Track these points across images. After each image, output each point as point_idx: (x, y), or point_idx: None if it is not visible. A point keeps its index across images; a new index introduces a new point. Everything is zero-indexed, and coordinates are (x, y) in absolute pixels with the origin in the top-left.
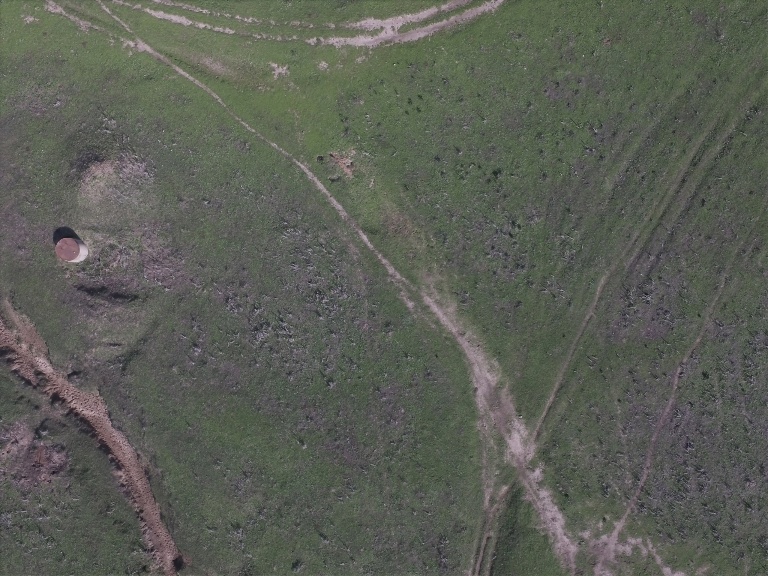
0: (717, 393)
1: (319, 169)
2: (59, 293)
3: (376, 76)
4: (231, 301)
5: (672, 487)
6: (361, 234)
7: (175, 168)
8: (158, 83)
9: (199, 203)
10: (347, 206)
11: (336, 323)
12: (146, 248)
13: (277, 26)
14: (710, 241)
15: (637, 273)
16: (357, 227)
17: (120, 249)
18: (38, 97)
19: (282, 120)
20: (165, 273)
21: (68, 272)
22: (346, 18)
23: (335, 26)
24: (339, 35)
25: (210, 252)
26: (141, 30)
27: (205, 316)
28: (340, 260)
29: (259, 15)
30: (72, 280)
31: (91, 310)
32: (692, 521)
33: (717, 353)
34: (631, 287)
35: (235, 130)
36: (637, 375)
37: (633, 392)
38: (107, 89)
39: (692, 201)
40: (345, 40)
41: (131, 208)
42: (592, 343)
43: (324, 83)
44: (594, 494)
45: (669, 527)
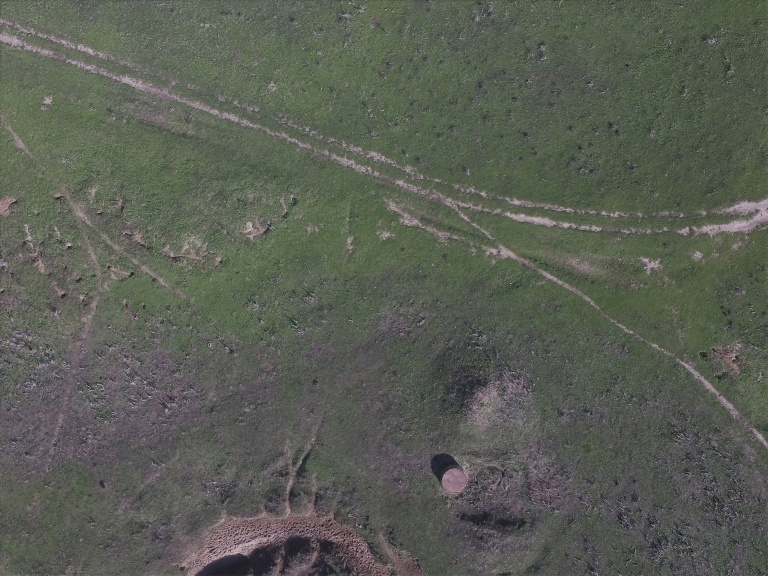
0: None
1: (705, 367)
2: (442, 525)
3: (756, 262)
4: (624, 517)
5: None
6: (756, 433)
7: (551, 379)
8: (526, 291)
9: (580, 415)
10: (738, 404)
11: (738, 531)
12: (532, 469)
13: (646, 219)
14: None
15: None
16: (750, 425)
17: (502, 472)
18: (400, 317)
19: (660, 318)
20: (552, 493)
21: (448, 501)
22: (718, 204)
23: (707, 213)
24: (713, 223)
25: (596, 466)
26: (503, 236)
27: (597, 535)
28: (735, 463)
29: (626, 209)
30: (453, 509)
31: (482, 543)
32: None
33: None
34: None
35: (611, 333)
36: None
37: None
38: (473, 302)
39: None
40: (719, 227)
41: (517, 430)
42: None
43: (701, 275)
44: None
45: None
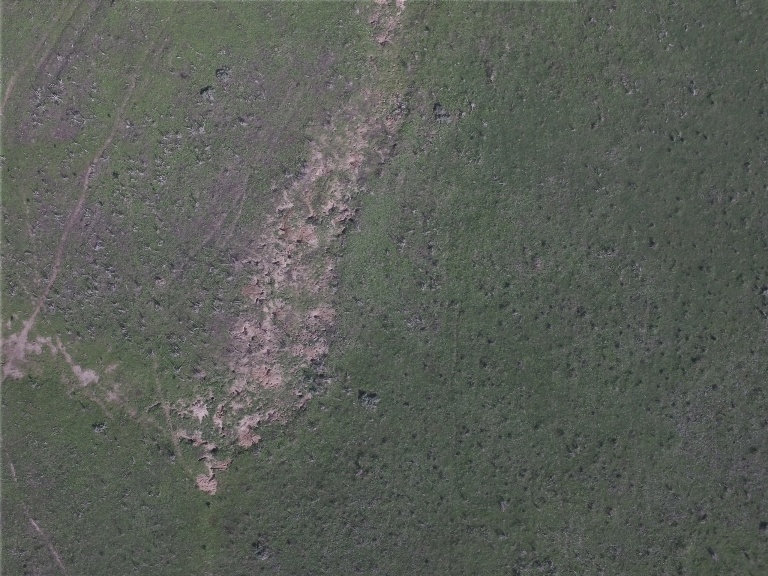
0: (128, 192)
1: None
2: None
3: None
4: None
5: (82, 286)
6: None
7: None
8: None
9: None
10: None
11: None
12: None
13: None
14: (119, 41)
15: (45, 73)
16: None
17: None
18: None
19: None
20: None
21: None
22: None
23: None
24: None
25: None
26: None
27: None
28: None
29: None
30: None
31: None
32: (102, 319)
33: (128, 153)
34: (39, 87)
35: None
36: (46, 175)
37: (42, 192)
38: None
39: (102, 2)
40: None
41: None
42: (0, 143)
43: None
44: (1, 293)
45: (78, 325)
